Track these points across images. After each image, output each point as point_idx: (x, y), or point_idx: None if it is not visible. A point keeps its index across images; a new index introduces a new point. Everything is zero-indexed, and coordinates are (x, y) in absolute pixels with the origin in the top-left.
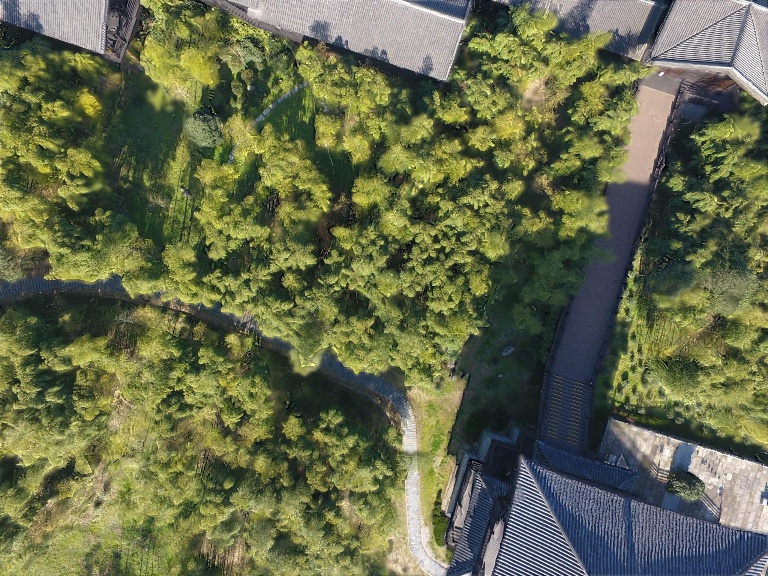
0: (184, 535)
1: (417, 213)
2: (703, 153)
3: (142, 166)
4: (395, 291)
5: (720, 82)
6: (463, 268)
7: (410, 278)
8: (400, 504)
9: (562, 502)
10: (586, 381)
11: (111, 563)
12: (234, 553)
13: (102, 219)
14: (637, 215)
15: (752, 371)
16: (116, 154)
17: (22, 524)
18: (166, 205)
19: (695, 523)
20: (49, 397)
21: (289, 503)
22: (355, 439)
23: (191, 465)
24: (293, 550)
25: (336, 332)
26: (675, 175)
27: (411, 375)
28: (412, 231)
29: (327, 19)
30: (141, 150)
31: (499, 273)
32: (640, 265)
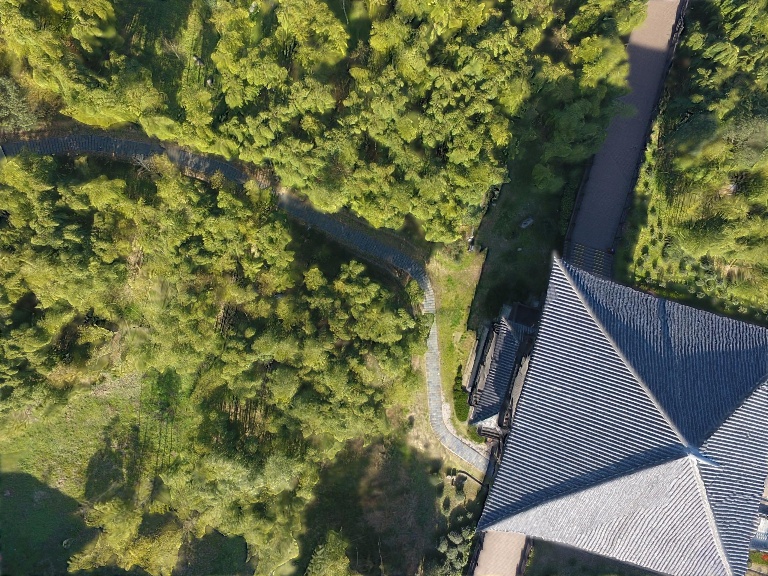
0: (205, 388)
1: (435, 64)
2: (723, 12)
3: (154, 34)
4: (415, 139)
5: None
6: (483, 118)
7: (430, 125)
8: (420, 380)
9: (596, 299)
10: (607, 249)
11: (129, 436)
12: (256, 406)
13: (117, 62)
14: (656, 81)
15: None
16: (127, 22)
17: (41, 372)
18: (179, 73)
19: (731, 322)
20: (67, 234)
21: (312, 351)
22: (377, 289)
23: (211, 314)
24: (316, 399)
25: (356, 178)
26: (695, 34)
27: (432, 226)
28: (432, 75)
29: None
30: (152, 19)
31: (519, 130)
32: (658, 139)
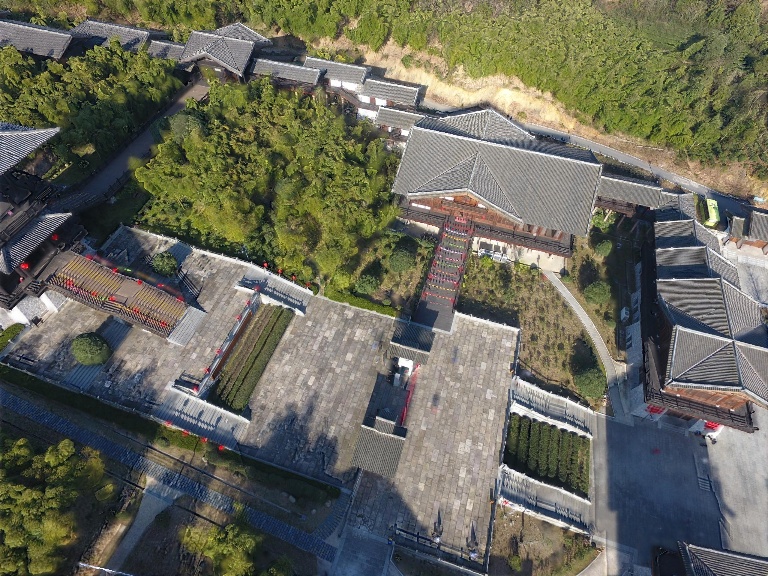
0: None
1: None
2: None
3: None
4: None
5: (234, 79)
6: None
7: None
8: None
9: None
10: None
11: None
12: None
13: None
14: None
15: (201, 172)
16: None
17: None
18: None
19: None
20: None
21: None
22: None
23: None
24: None
25: None
26: None
27: None
28: None
29: (8, 39)
30: None
31: None
32: None
